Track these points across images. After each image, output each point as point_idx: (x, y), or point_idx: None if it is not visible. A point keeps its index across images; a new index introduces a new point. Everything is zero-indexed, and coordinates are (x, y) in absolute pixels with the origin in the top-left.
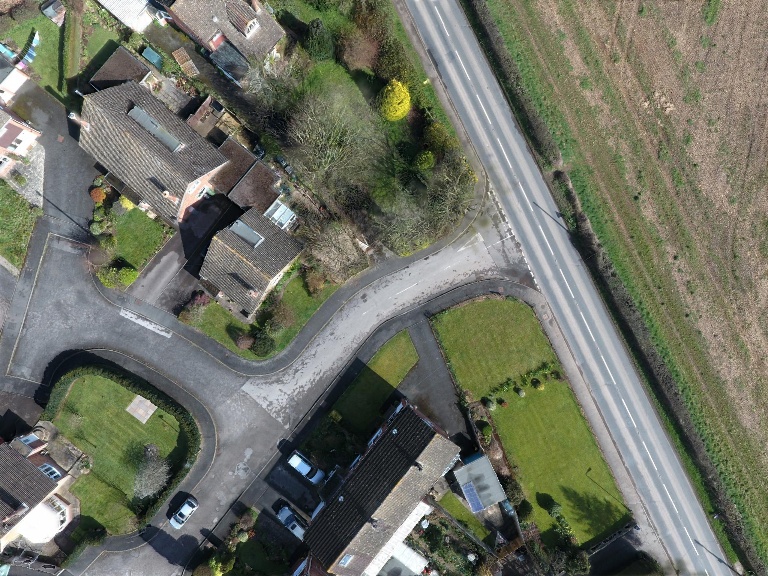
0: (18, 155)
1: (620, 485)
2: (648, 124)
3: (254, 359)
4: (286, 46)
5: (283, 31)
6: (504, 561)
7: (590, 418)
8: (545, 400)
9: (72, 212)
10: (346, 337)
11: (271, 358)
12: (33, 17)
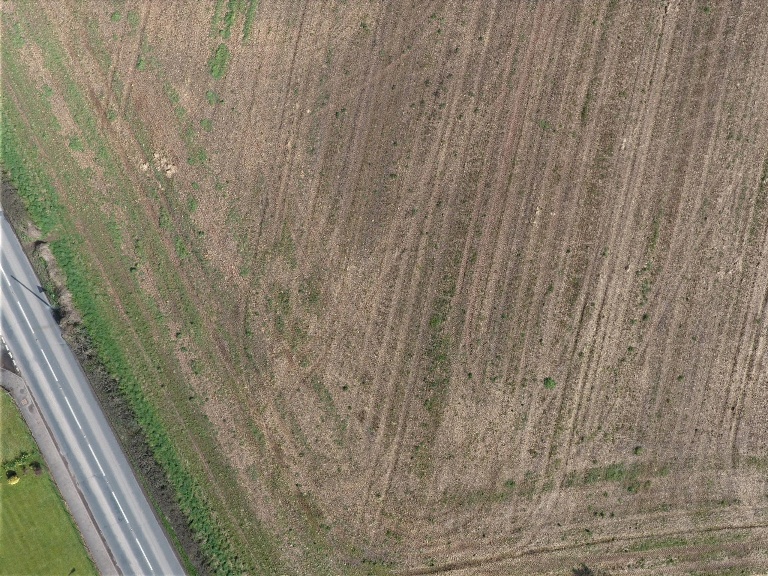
0: None
1: None
2: (147, 188)
3: None
4: None
5: None
6: None
7: (74, 513)
8: (23, 494)
9: None
10: None
11: None
12: None
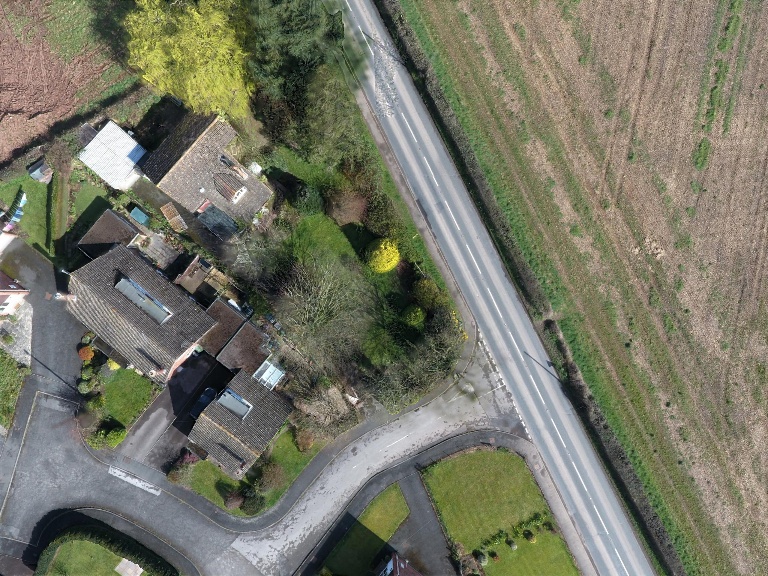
0: (6, 315)
1: None
2: (639, 270)
3: (244, 516)
4: (275, 200)
5: (271, 192)
6: None
7: (583, 569)
8: (537, 551)
9: (60, 370)
10: (336, 491)
11: (261, 514)
12: (21, 176)
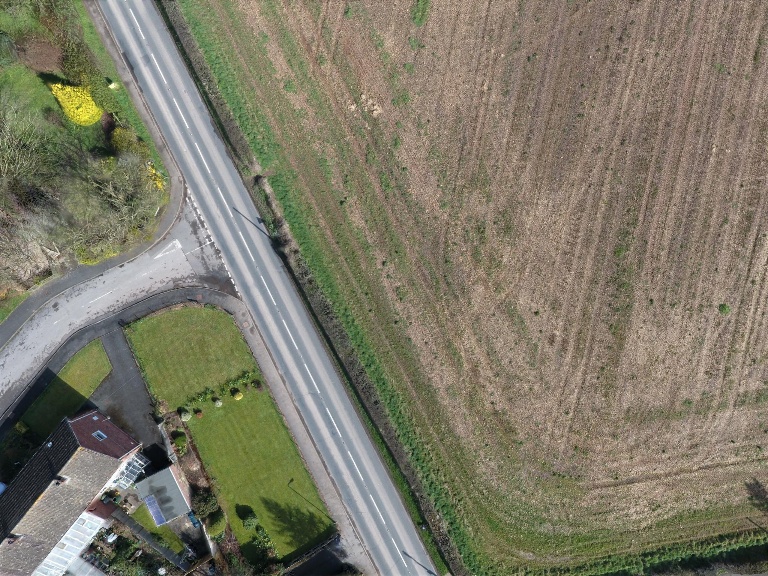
0: None
1: (324, 496)
2: (355, 127)
3: None
4: None
5: None
6: (202, 574)
7: (292, 428)
8: (245, 410)
9: None
10: (36, 347)
11: None
12: None
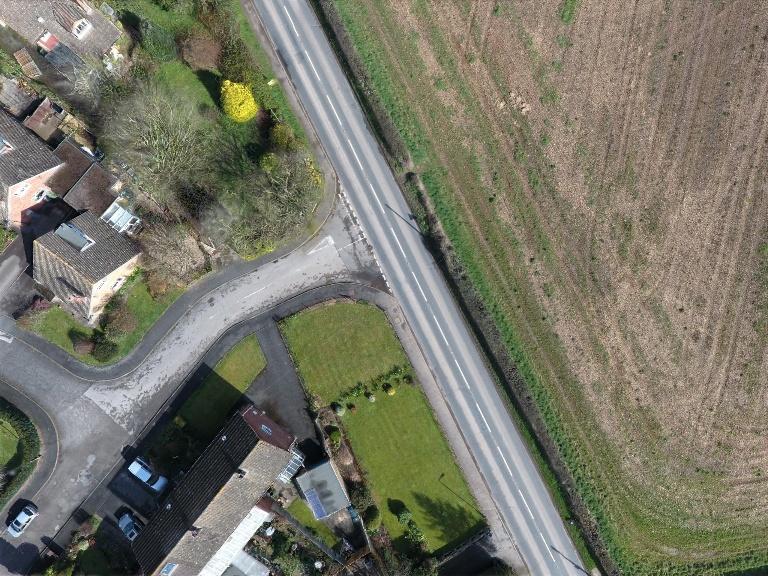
0: None
1: (474, 491)
2: (504, 125)
3: (97, 364)
4: (130, 46)
5: (120, 31)
6: (355, 568)
7: (443, 423)
8: (397, 405)
9: None
10: (192, 342)
11: (114, 363)
12: None
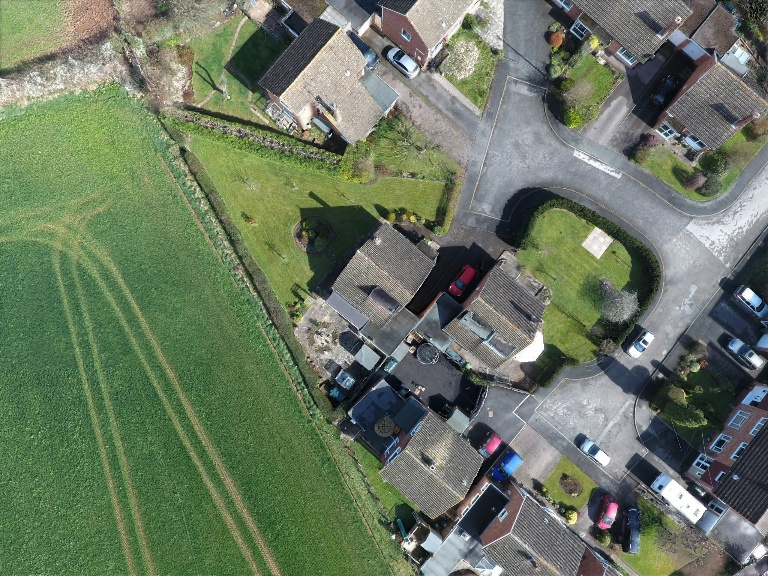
0: None
1: None
2: None
3: (699, 200)
4: None
5: None
6: None
7: None
8: None
9: (530, 56)
10: None
11: (714, 199)
12: None
